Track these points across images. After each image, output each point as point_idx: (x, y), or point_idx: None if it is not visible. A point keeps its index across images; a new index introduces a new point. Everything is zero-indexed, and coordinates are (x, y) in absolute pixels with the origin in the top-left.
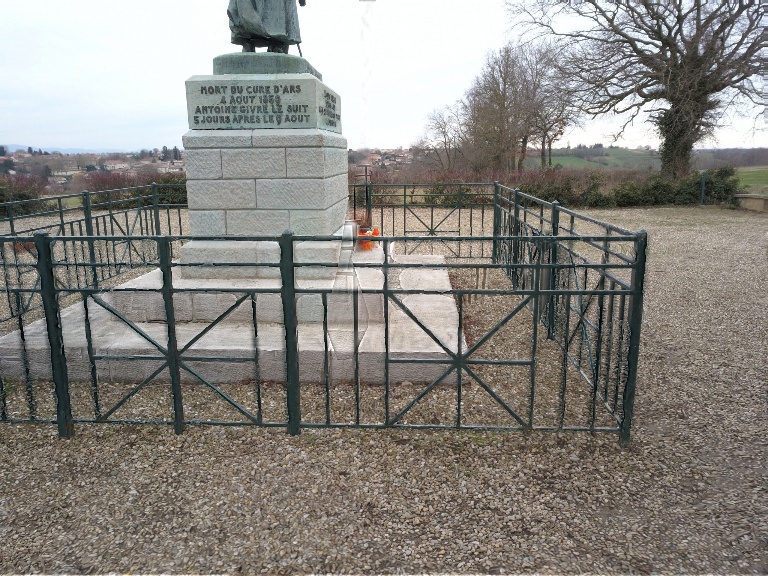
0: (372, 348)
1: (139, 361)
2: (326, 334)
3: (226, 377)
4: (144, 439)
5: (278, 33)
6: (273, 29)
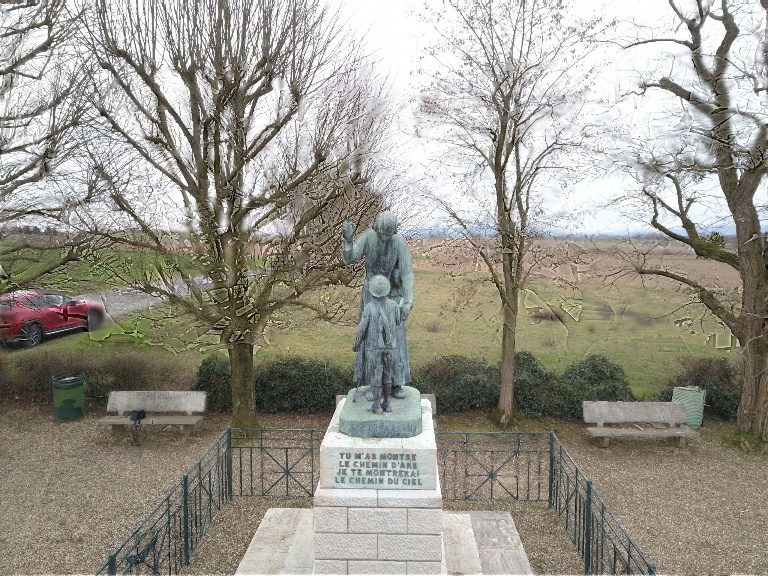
0: None
1: None
2: None
3: None
4: None
5: None
6: None
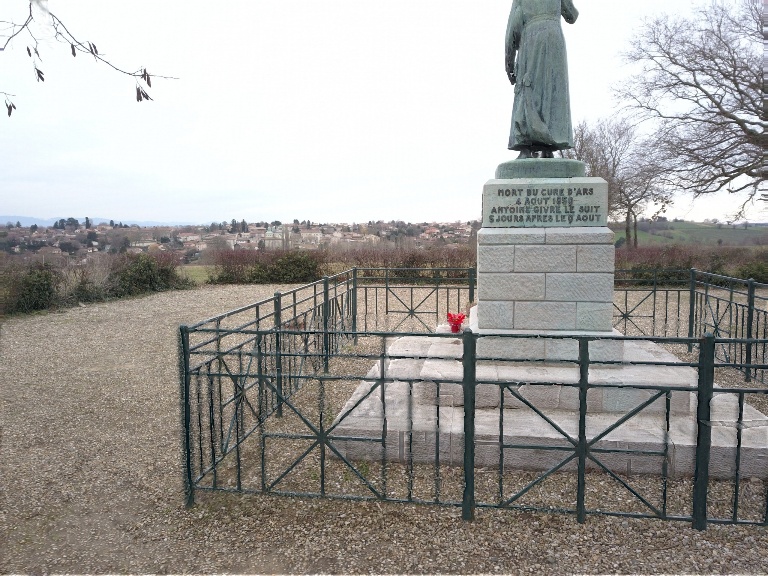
0: (713, 442)
1: (480, 446)
2: (740, 432)
3: (565, 465)
4: (549, 526)
5: (563, 141)
6: (558, 137)
